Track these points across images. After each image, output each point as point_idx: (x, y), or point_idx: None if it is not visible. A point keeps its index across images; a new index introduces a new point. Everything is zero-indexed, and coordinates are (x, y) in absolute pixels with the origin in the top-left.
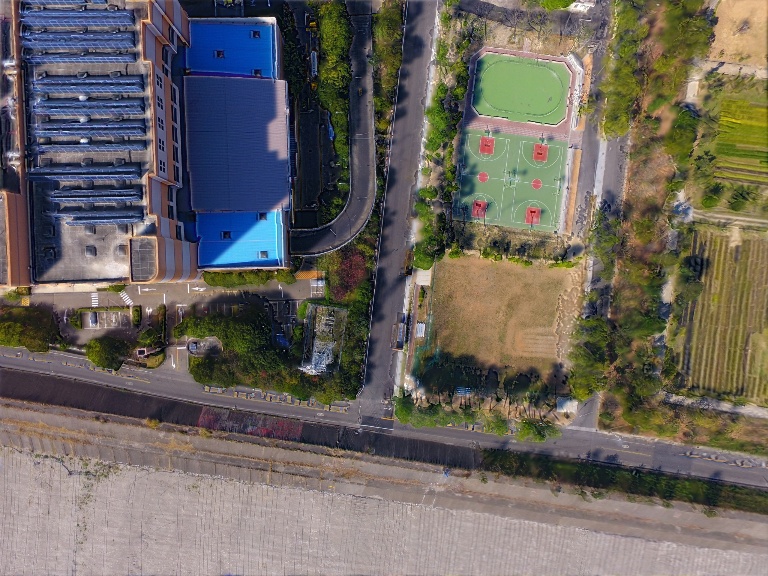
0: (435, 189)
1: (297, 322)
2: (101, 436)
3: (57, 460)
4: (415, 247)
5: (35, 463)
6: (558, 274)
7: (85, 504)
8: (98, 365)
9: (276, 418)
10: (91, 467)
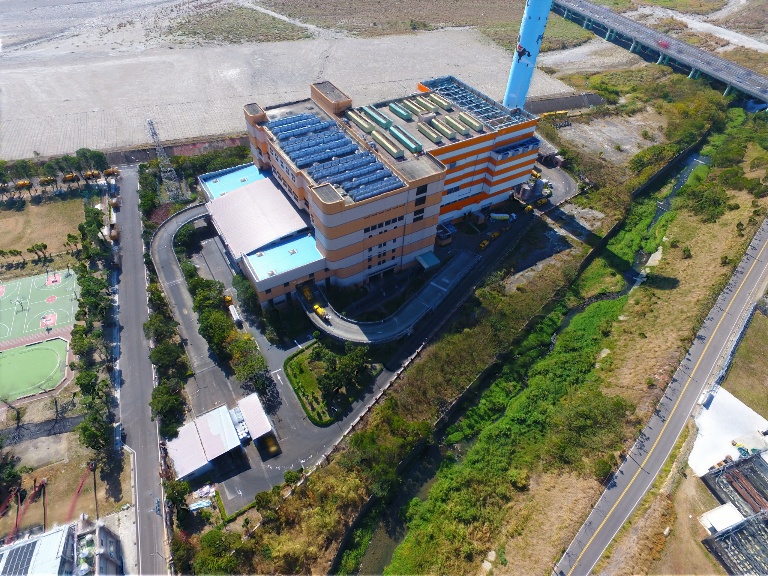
0: (91, 252)
1: (196, 191)
2: None
3: None
4: (112, 244)
5: None
6: None
7: None
8: None
9: (194, 155)
10: None
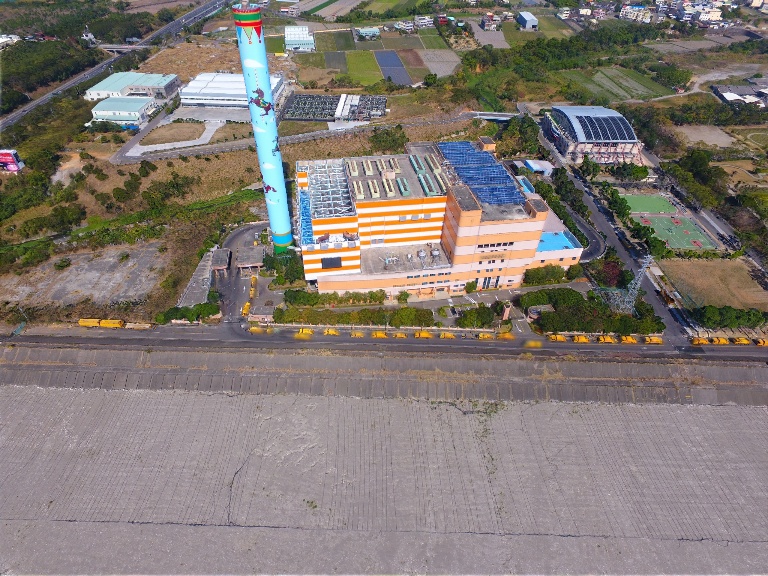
0: (639, 224)
1: None
2: (486, 375)
3: (450, 404)
4: None
5: (432, 408)
6: (736, 264)
7: (485, 437)
8: (476, 321)
9: None
10: (480, 407)
